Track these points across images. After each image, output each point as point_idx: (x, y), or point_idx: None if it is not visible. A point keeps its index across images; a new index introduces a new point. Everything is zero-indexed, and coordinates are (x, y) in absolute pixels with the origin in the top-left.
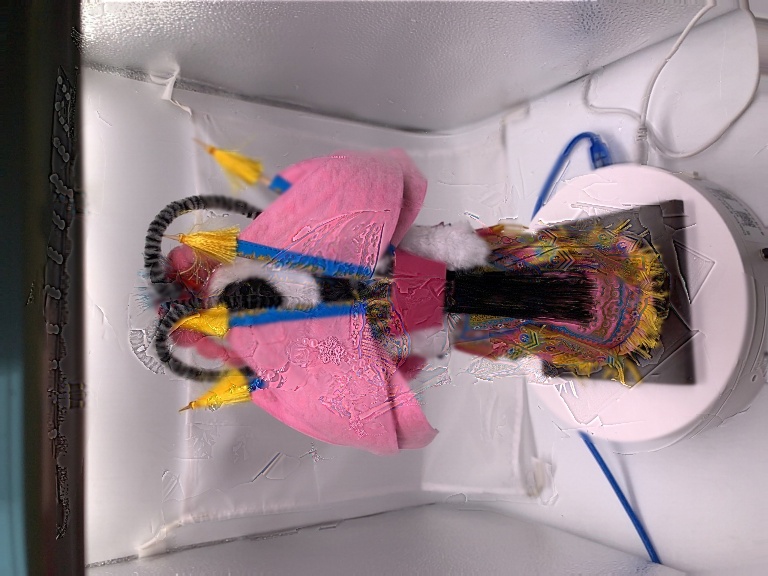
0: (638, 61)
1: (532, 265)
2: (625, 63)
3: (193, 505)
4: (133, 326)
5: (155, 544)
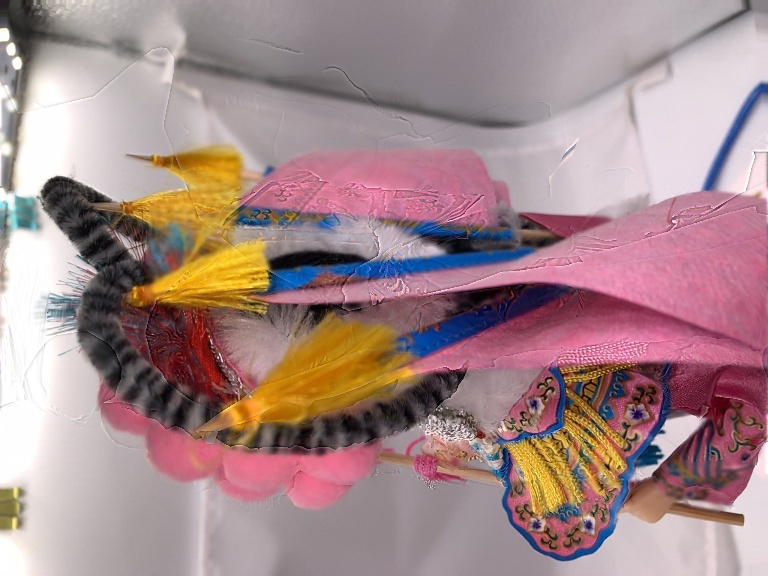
0: None
1: None
2: None
3: None
4: None
5: None
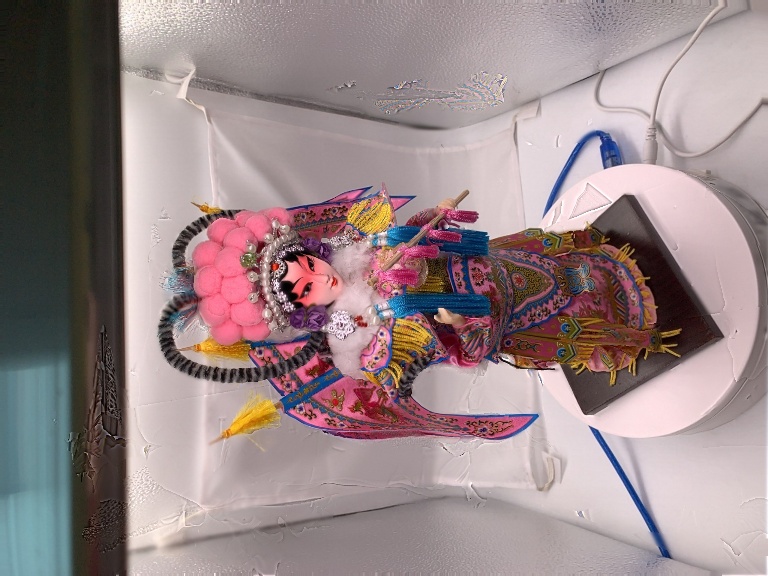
0: None
1: None
2: None
3: None
4: (152, 258)
5: None
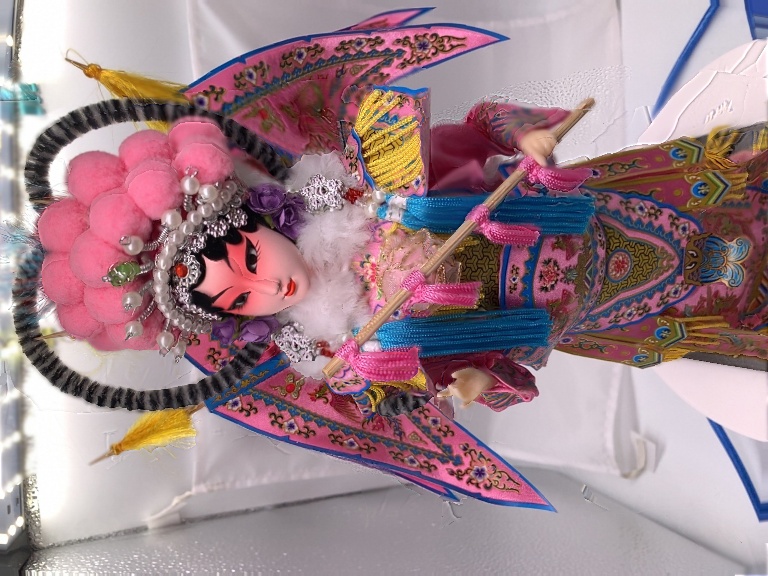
0: (624, 126)
1: None
2: (612, 130)
3: None
4: None
5: None
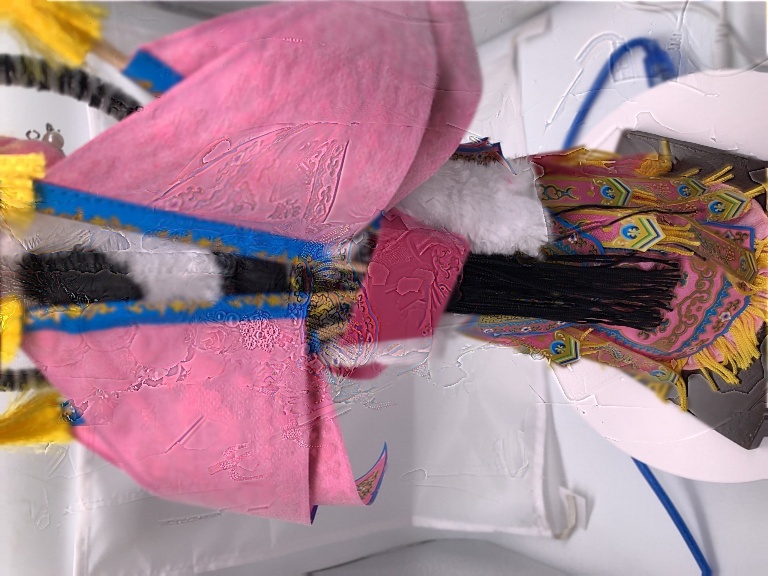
0: None
1: (591, 238)
2: None
3: (85, 485)
4: None
5: (33, 536)
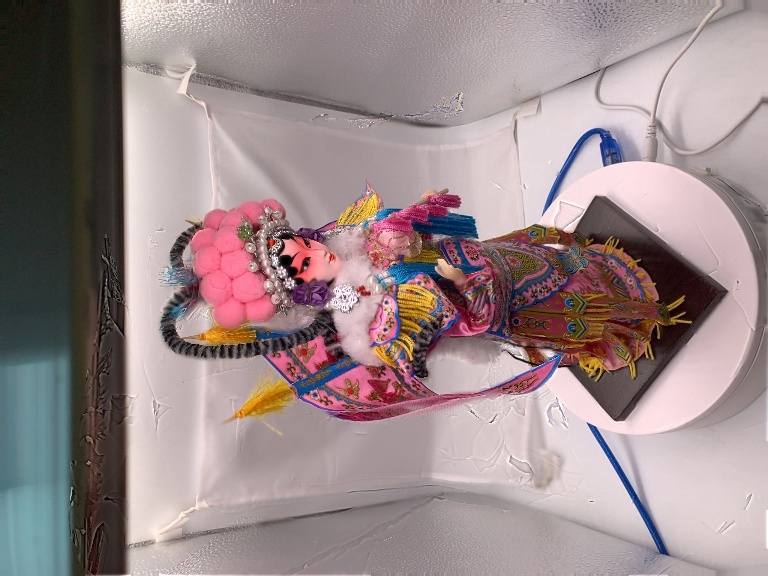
0: None
1: None
2: None
3: None
4: None
5: None
